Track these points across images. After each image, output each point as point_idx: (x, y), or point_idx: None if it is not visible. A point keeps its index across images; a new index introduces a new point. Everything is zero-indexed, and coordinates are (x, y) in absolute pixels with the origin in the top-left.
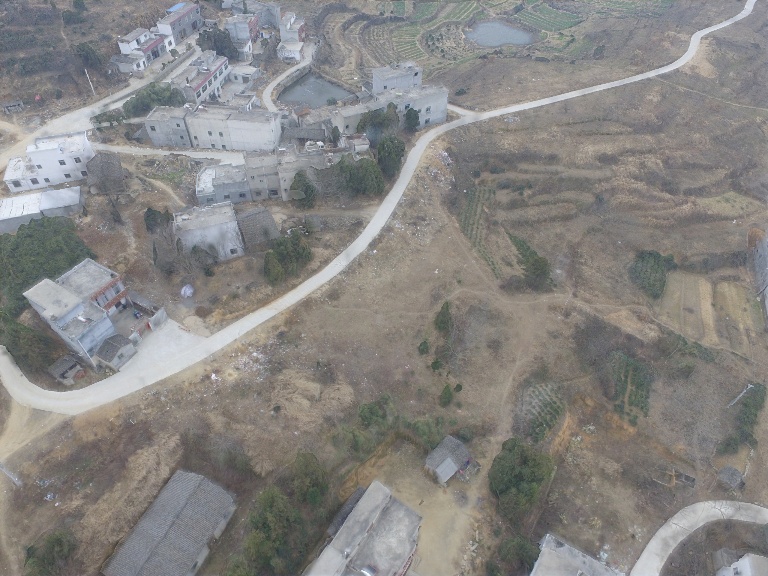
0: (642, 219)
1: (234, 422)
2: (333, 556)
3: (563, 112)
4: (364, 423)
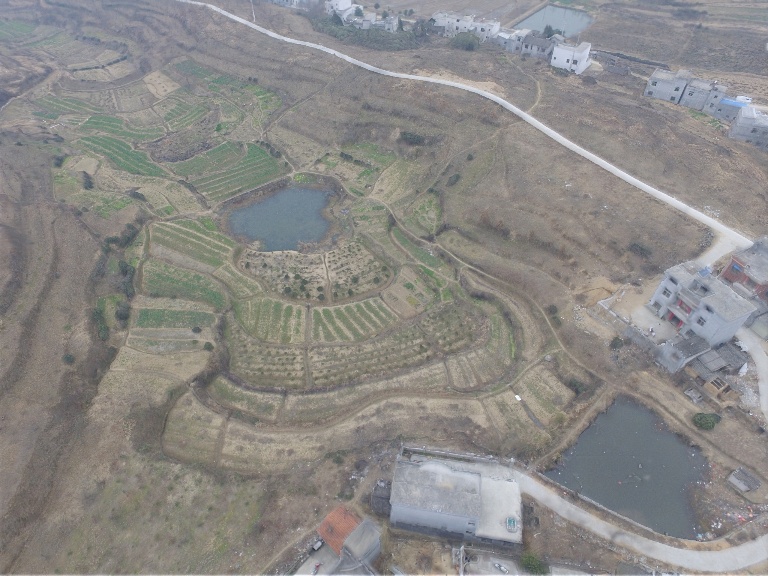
0: (765, 178)
1: None
2: None
3: (664, 175)
4: None
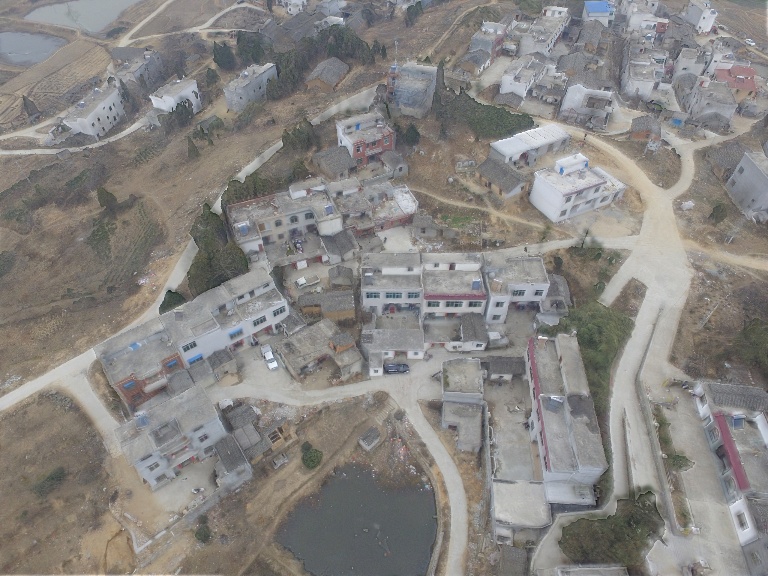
0: None
1: (313, 97)
2: (258, 71)
3: None
4: (249, 113)
